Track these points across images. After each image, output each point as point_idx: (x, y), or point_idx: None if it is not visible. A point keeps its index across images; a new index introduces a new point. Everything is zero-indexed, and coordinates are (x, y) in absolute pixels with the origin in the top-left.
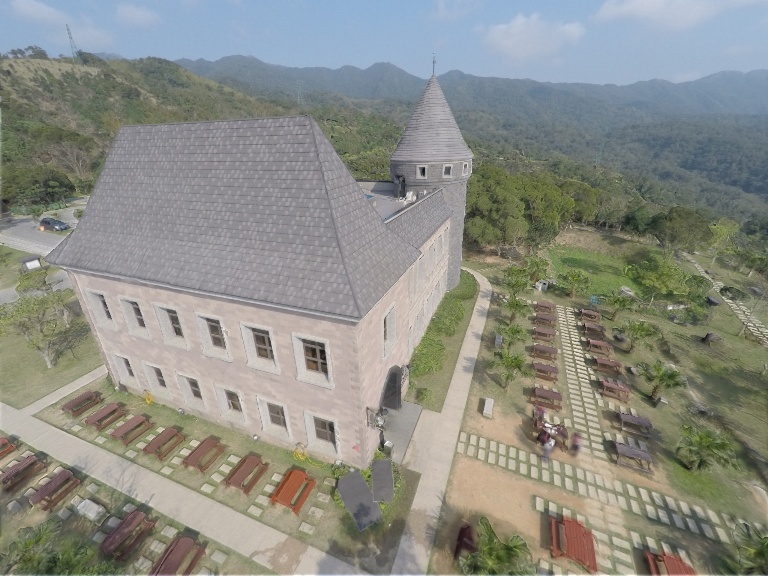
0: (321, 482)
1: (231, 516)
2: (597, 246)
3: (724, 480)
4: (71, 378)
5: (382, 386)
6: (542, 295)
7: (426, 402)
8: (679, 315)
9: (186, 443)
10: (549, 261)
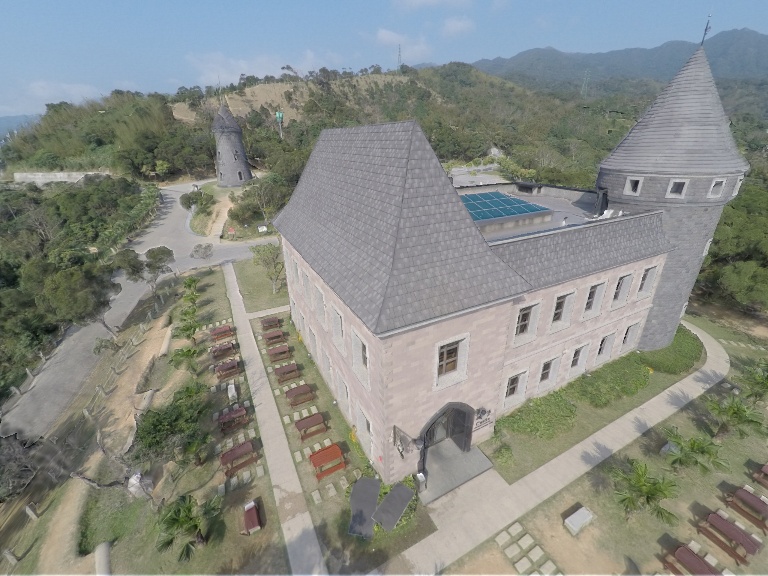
0: (352, 469)
1: (284, 449)
2: None
3: None
4: (278, 304)
5: (430, 415)
6: None
7: (500, 463)
8: None
9: (298, 380)
10: None
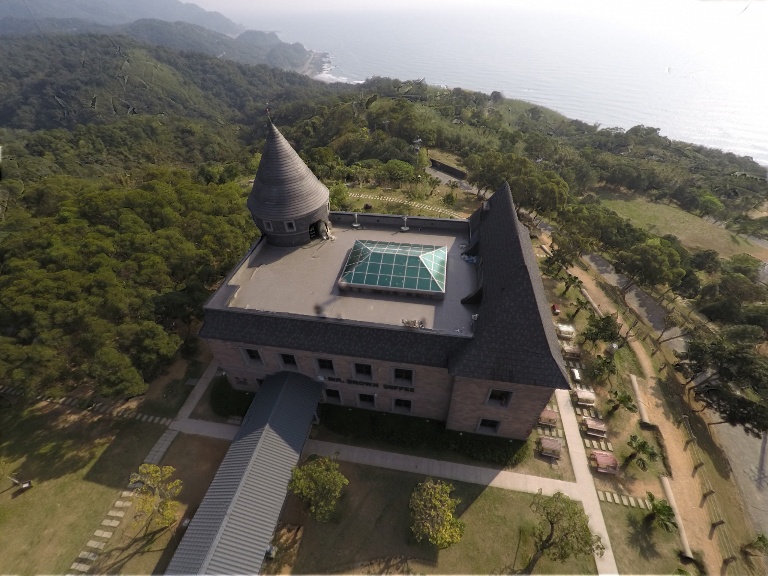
0: None
1: None
2: None
3: None
4: None
5: None
6: None
7: None
8: None
9: None
10: None
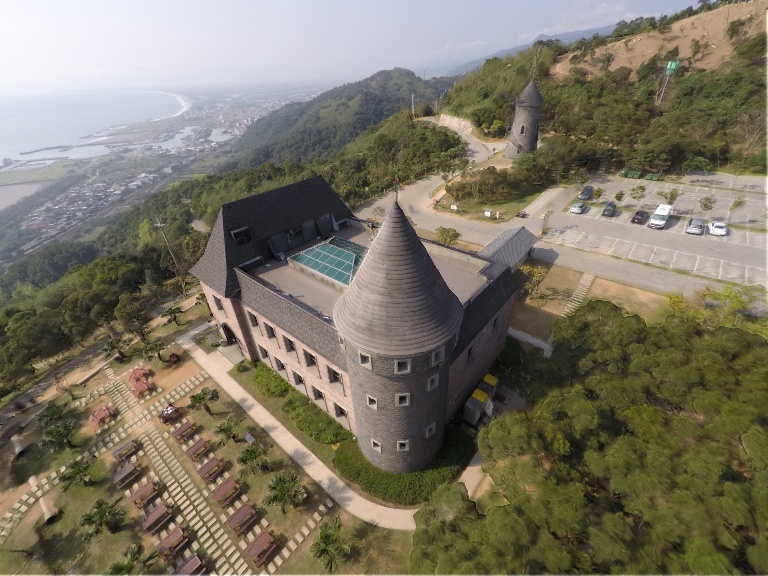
0: None
1: None
2: None
3: (70, 502)
4: None
5: None
6: None
7: None
8: None
9: None
10: None
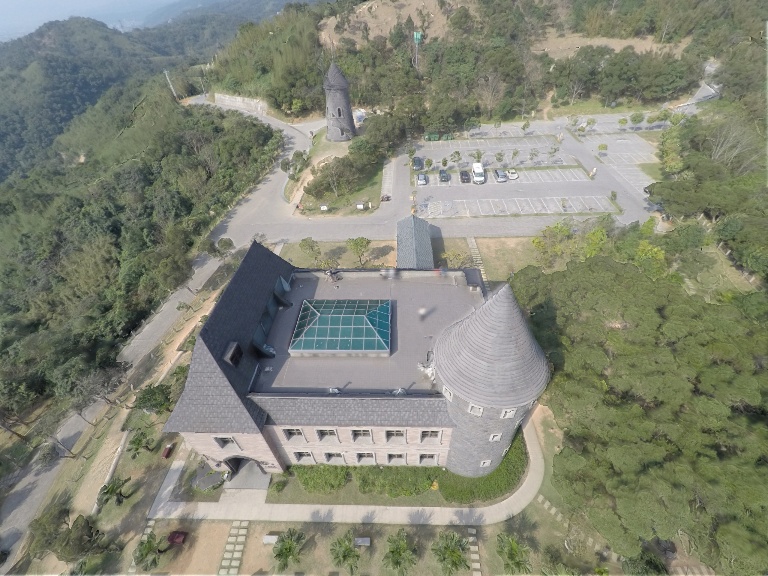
0: None
1: None
2: None
3: None
4: None
5: (226, 456)
6: None
7: None
8: None
9: None
10: None
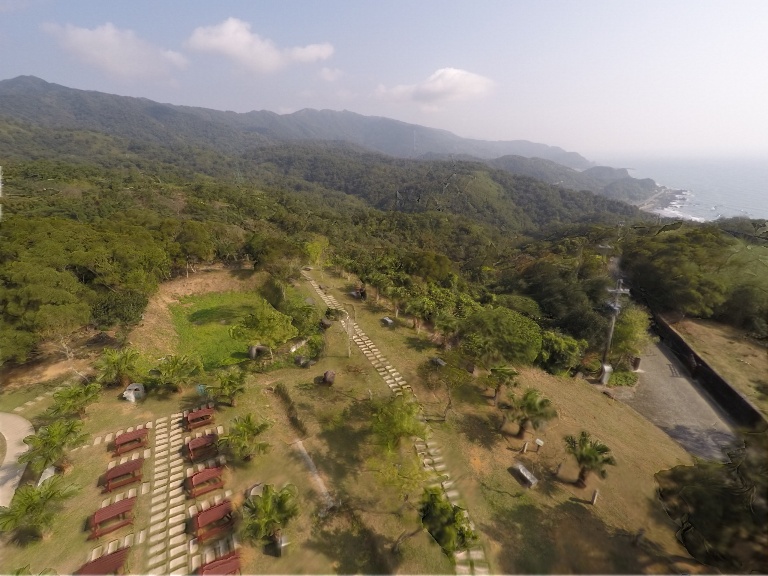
0: None
1: None
2: (228, 286)
3: None
4: None
5: None
6: (135, 410)
7: None
8: (304, 352)
9: None
10: (167, 329)
